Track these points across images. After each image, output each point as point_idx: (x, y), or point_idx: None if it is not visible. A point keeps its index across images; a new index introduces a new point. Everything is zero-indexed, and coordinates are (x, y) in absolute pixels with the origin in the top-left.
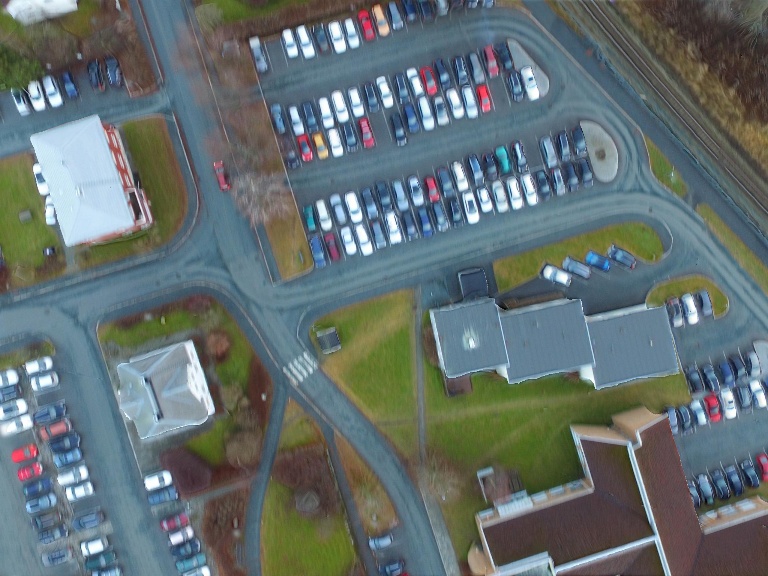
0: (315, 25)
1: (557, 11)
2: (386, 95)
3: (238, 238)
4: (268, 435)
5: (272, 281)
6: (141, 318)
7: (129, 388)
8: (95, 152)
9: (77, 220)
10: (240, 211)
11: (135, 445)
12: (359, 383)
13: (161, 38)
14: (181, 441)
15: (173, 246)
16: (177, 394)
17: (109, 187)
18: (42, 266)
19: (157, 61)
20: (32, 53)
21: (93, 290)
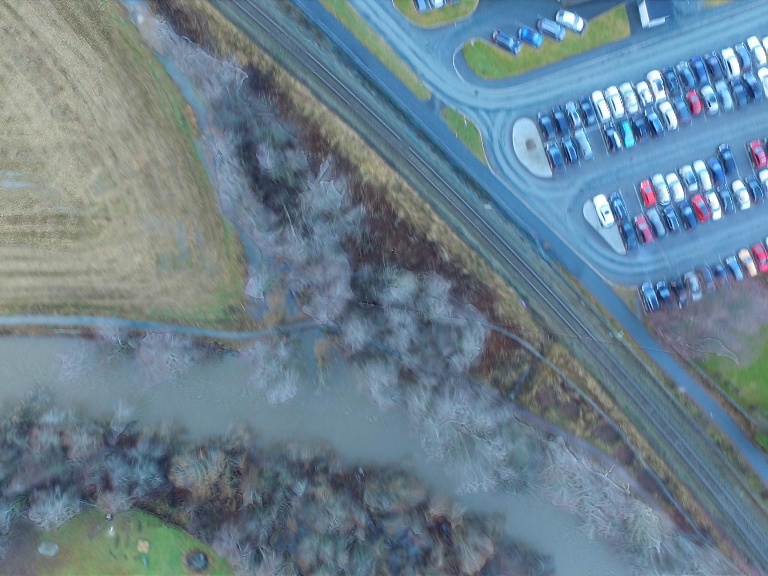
0: None
1: (580, 284)
2: (743, 190)
3: None
4: None
5: None
6: None
7: None
8: None
9: None
10: None
11: None
12: None
13: None
14: None
15: None
16: None
17: None
18: None
19: None
20: None
21: None
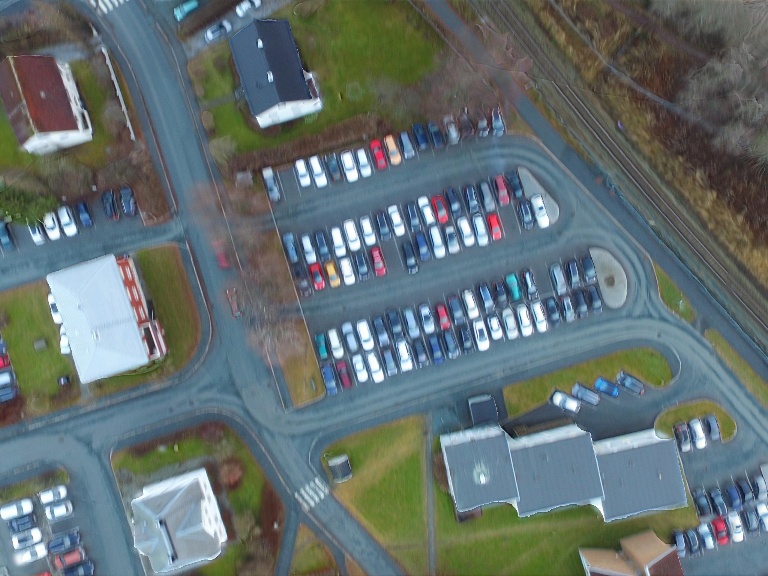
0: (327, 155)
1: (567, 139)
2: (398, 224)
3: (251, 365)
4: (280, 561)
5: (284, 408)
6: (154, 445)
7: (143, 526)
8: (110, 292)
9: (93, 361)
10: (253, 338)
11: (148, 571)
12: (370, 508)
13: (175, 167)
14: (194, 567)
15: (186, 373)
16: (191, 533)
17: (124, 327)
18: (56, 394)
19: (171, 190)
20: (48, 189)
21: (107, 418)
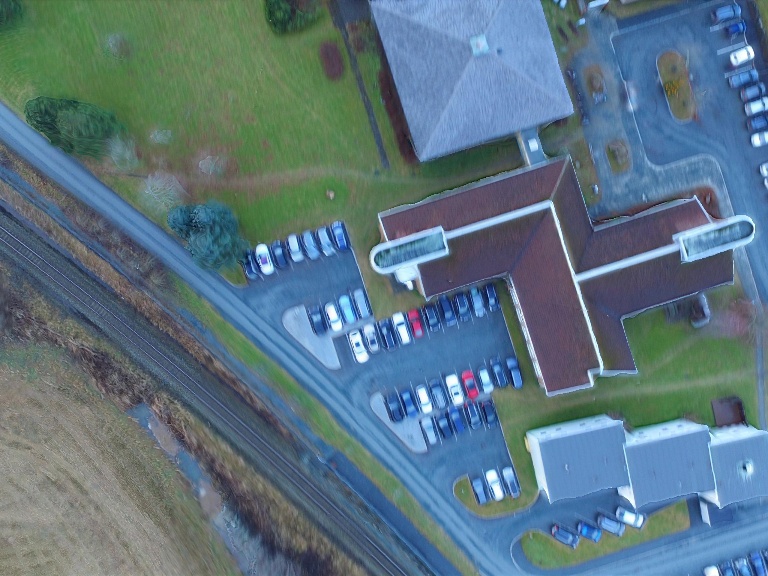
0: None
1: None
2: None
3: None
4: None
5: None
6: None
7: None
8: None
9: None
10: None
11: None
12: None
13: None
14: None
15: None
16: None
17: None
18: None
19: None
20: None
21: None
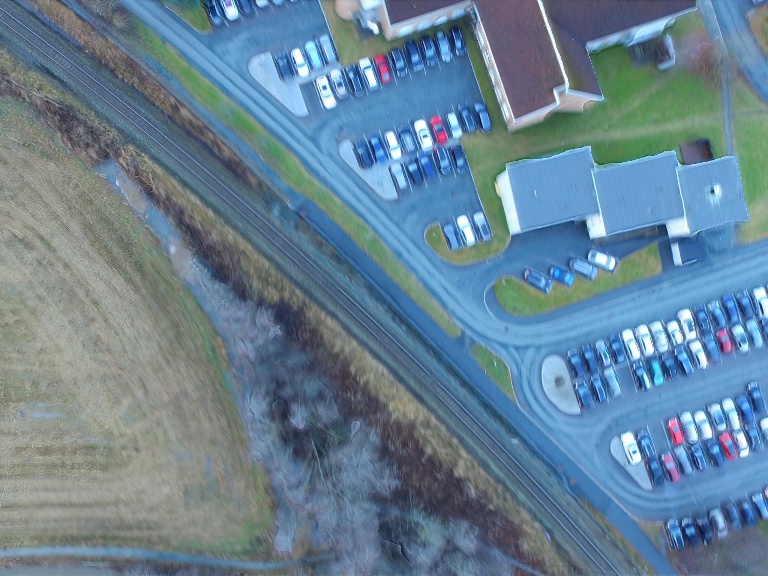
0: None
1: (605, 520)
2: None
3: None
4: None
5: None
6: None
7: None
8: None
9: None
10: None
11: None
12: None
13: None
14: None
15: None
16: None
17: None
18: None
19: None
20: None
21: None
